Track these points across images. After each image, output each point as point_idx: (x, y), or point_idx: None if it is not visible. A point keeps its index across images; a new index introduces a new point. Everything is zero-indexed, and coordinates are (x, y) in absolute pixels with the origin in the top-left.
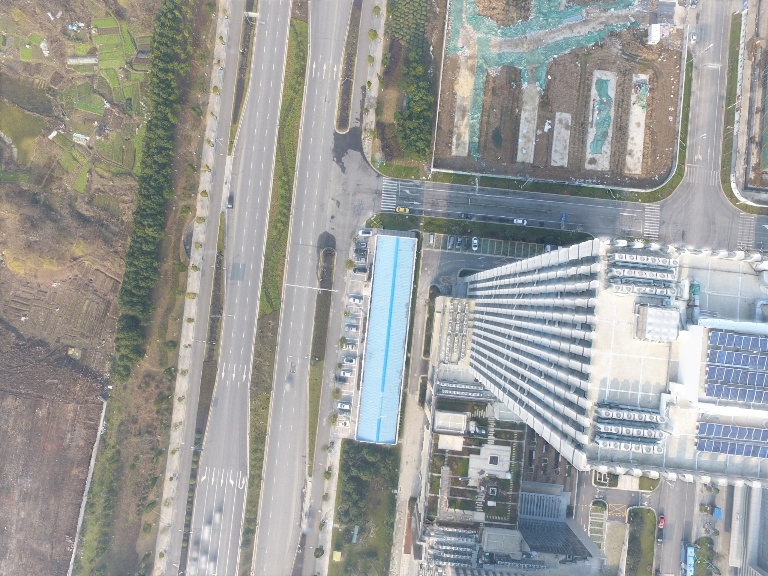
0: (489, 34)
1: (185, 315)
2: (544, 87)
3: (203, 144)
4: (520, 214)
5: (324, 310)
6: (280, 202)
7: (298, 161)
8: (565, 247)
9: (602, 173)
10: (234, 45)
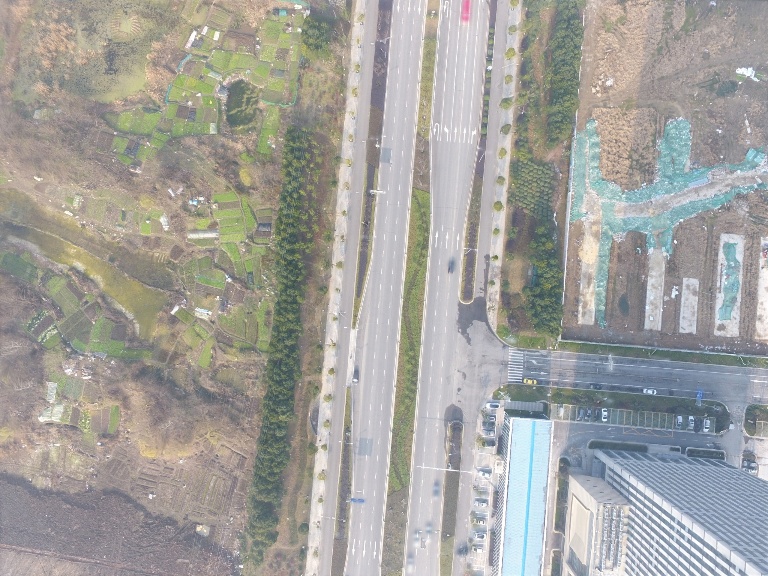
0: (613, 199)
1: (314, 492)
2: (671, 253)
3: (327, 318)
4: (649, 383)
5: (454, 485)
6: (407, 377)
7: (423, 333)
8: (696, 416)
9: (731, 339)
10: (355, 216)
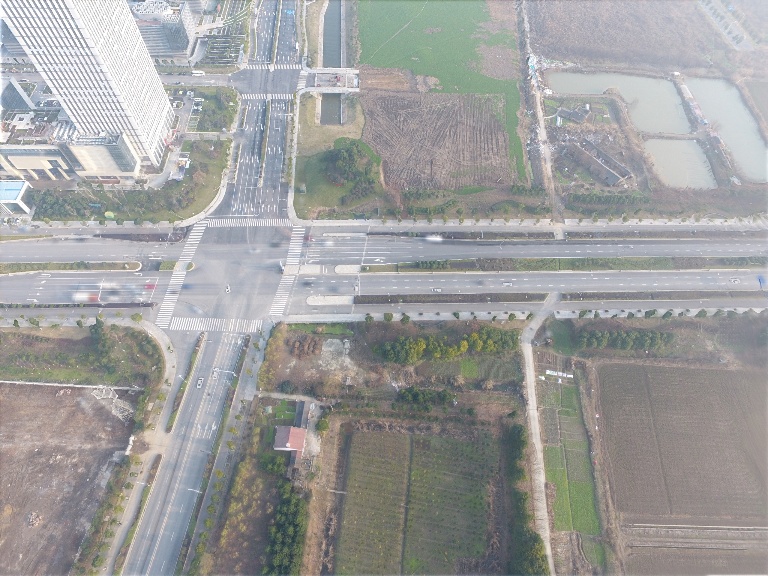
0: None
1: None
2: None
3: None
4: None
5: None
6: None
7: None
8: None
9: None
10: None
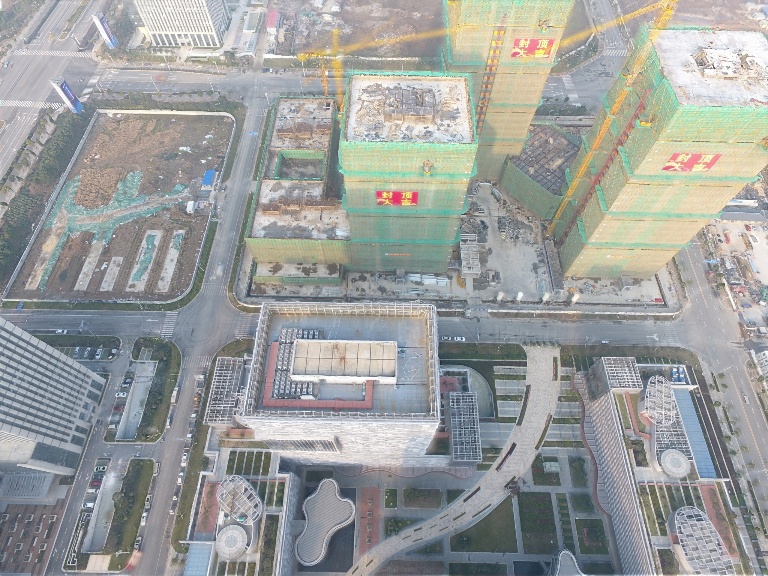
0: (77, 214)
1: None
2: (107, 242)
3: None
4: (65, 326)
5: None
6: None
7: None
8: (94, 348)
9: (138, 293)
10: None
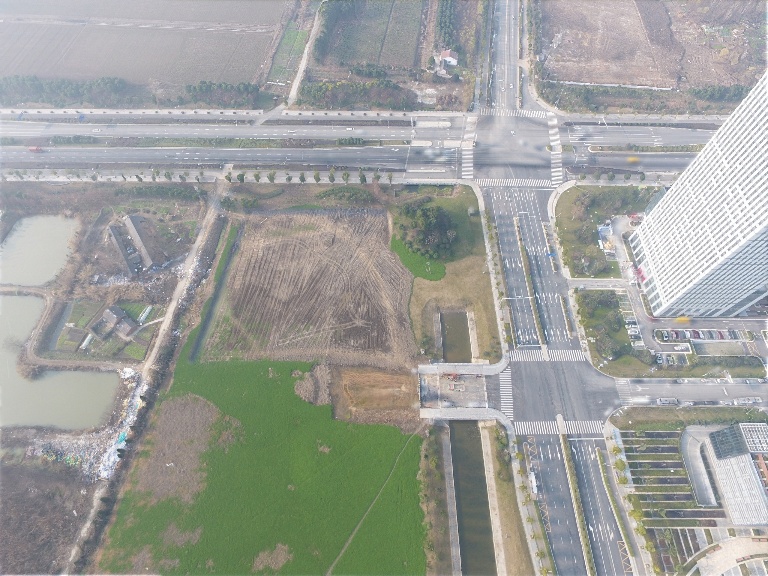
0: None
1: None
2: None
3: None
4: None
5: None
6: None
7: None
8: None
9: None
10: None
